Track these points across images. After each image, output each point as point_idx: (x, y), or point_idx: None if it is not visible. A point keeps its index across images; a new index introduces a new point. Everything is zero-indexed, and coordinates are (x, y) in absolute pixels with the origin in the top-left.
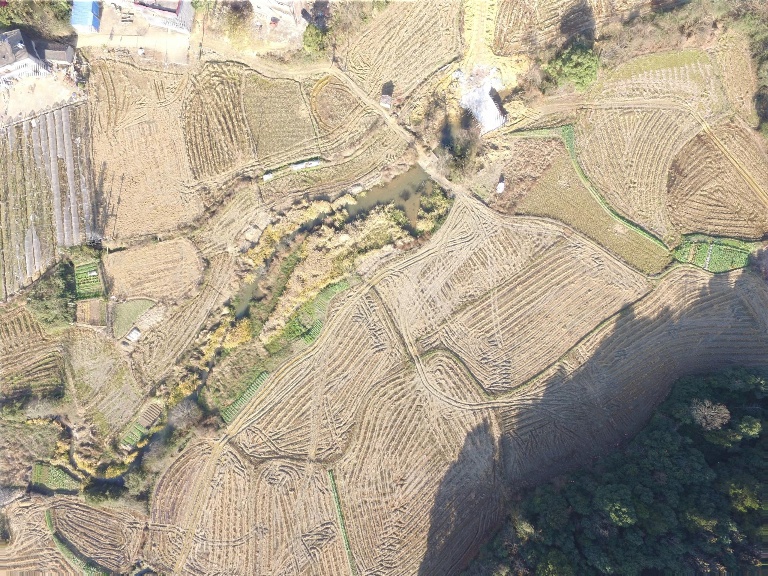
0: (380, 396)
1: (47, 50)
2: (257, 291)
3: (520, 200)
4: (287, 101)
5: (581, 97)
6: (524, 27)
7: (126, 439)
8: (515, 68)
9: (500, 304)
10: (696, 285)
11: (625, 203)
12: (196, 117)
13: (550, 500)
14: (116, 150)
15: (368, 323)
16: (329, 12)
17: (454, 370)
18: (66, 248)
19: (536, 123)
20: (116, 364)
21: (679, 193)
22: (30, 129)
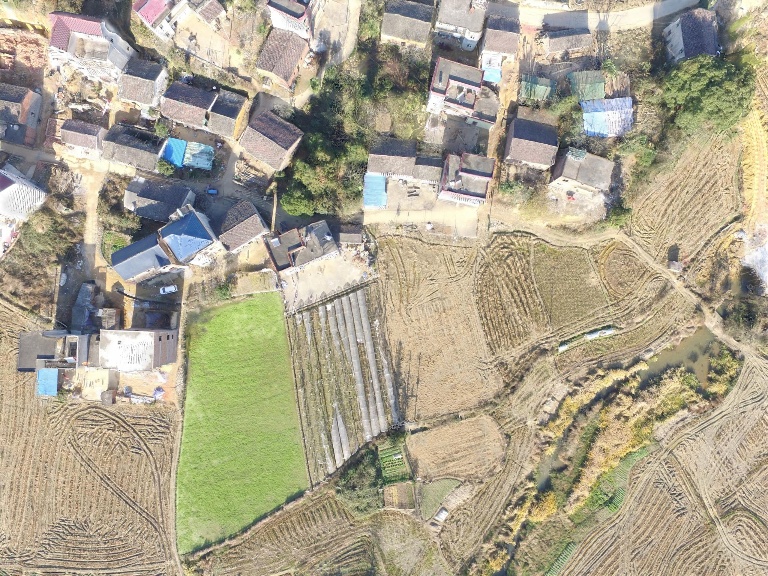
0: (685, 559)
1: (342, 233)
2: (556, 461)
3: None
4: (577, 270)
5: None
6: None
7: None
8: None
9: None
10: None
11: None
12: (489, 291)
13: None
14: (411, 329)
15: (669, 488)
16: (623, 182)
17: (753, 529)
18: (374, 435)
19: None
20: (426, 545)
21: None
22: (326, 314)
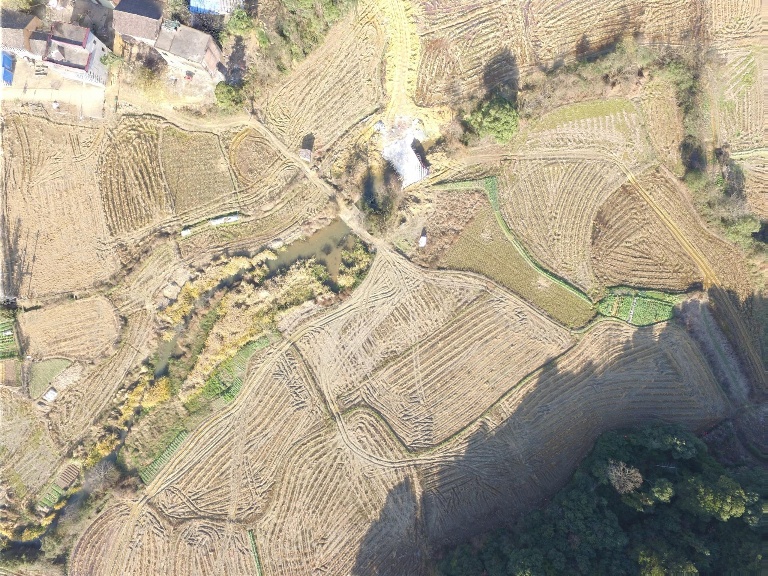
0: (301, 454)
1: None
2: (176, 348)
3: (442, 254)
4: (205, 155)
5: (505, 148)
6: (447, 77)
7: (43, 501)
8: (437, 119)
9: (422, 360)
10: (620, 339)
11: (549, 256)
12: (112, 172)
13: (465, 563)
14: (31, 206)
15: (288, 380)
16: (245, 65)
17: (375, 427)
18: None
19: (459, 175)
20: (32, 425)
21: (604, 245)
22: None
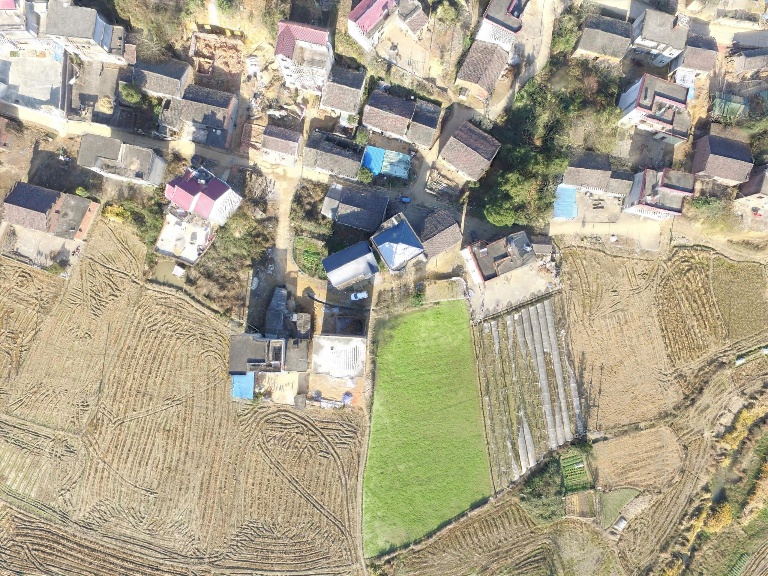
0: None
1: (533, 244)
2: (730, 473)
3: None
4: (754, 284)
5: None
6: None
7: None
8: None
9: None
10: None
11: None
12: (669, 304)
13: None
14: (594, 339)
15: None
16: None
17: None
18: (559, 444)
19: None
20: (604, 554)
21: None
22: (514, 323)
